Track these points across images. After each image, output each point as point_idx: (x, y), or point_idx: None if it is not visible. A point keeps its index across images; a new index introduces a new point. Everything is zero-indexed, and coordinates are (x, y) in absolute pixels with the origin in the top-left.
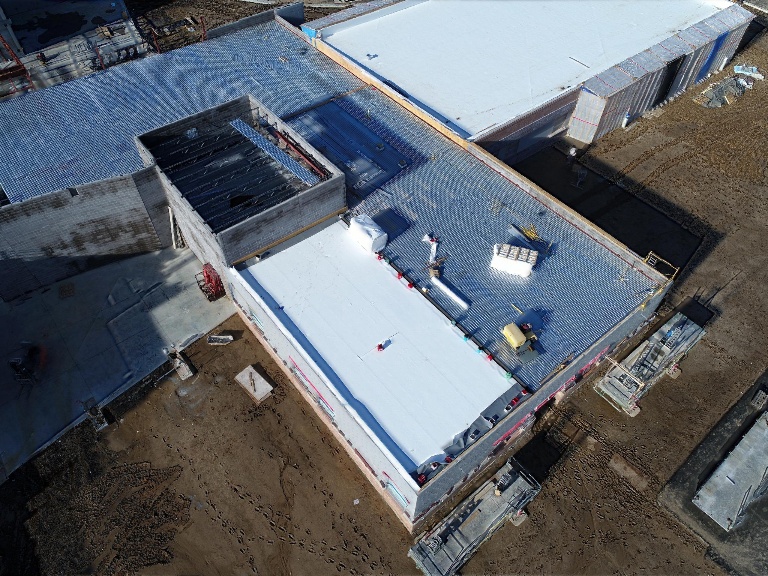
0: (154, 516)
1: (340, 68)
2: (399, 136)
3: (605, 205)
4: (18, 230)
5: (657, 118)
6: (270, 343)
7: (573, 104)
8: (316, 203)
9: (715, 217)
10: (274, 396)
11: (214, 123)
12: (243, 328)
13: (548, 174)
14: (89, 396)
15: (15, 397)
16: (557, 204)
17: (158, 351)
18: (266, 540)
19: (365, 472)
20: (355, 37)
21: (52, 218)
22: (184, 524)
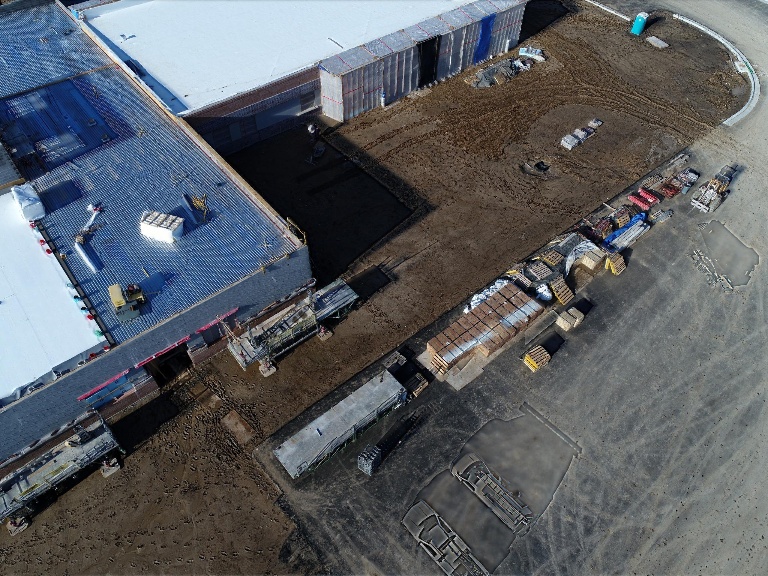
0: None
1: (97, 48)
2: (118, 112)
3: (331, 180)
4: None
5: (421, 98)
6: None
7: (316, 83)
8: None
9: (436, 191)
10: None
11: None
12: None
13: (288, 151)
14: None
15: None
16: (233, 175)
17: None
18: None
19: None
20: (121, 18)
21: None
22: None
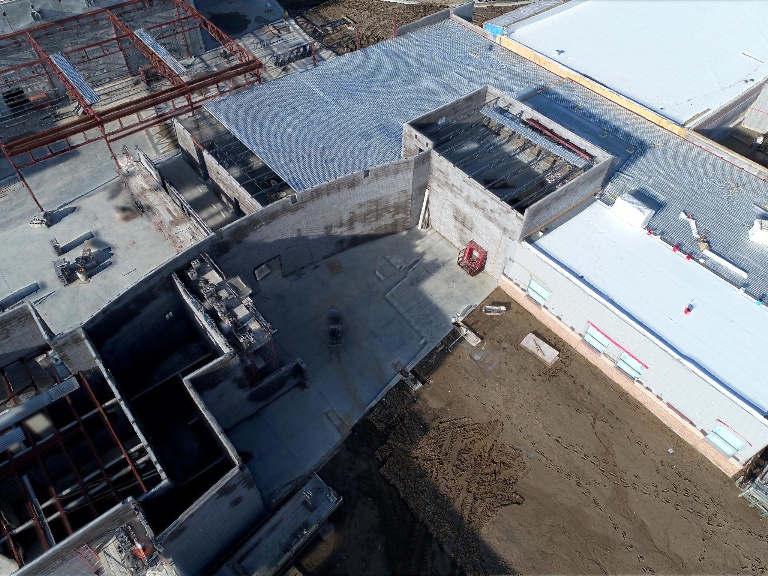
0: (493, 464)
1: (530, 63)
2: (615, 125)
3: None
4: (316, 209)
5: None
6: (552, 312)
7: (756, 96)
8: (587, 183)
9: None
10: (561, 360)
11: (465, 112)
12: (509, 300)
13: None
14: (395, 360)
15: (328, 361)
16: None
17: (441, 320)
18: (602, 484)
19: (672, 425)
20: (536, 34)
21: (343, 198)
22: (523, 471)
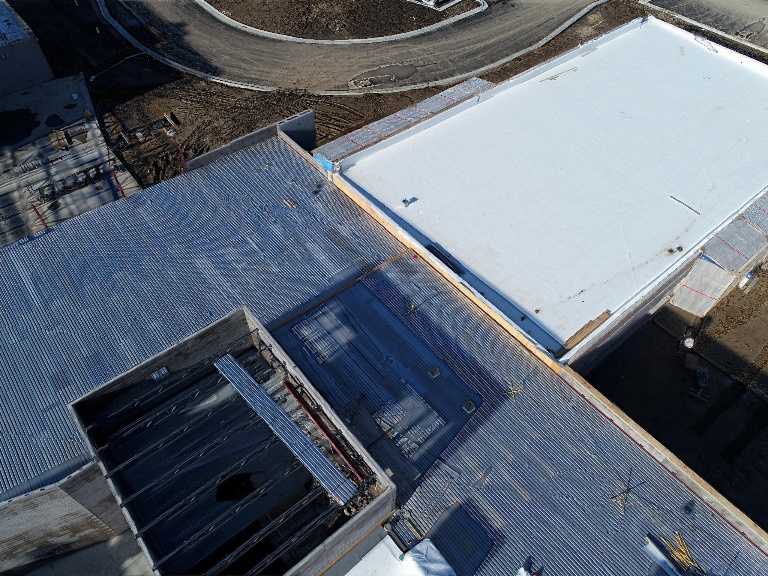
0: None
1: (366, 217)
2: (458, 347)
3: (742, 430)
4: None
5: None
6: None
7: (685, 273)
8: (351, 533)
9: None
10: None
11: None
12: None
13: (654, 372)
14: None
15: None
16: (713, 497)
17: None
18: None
19: None
20: (384, 168)
21: None
22: None
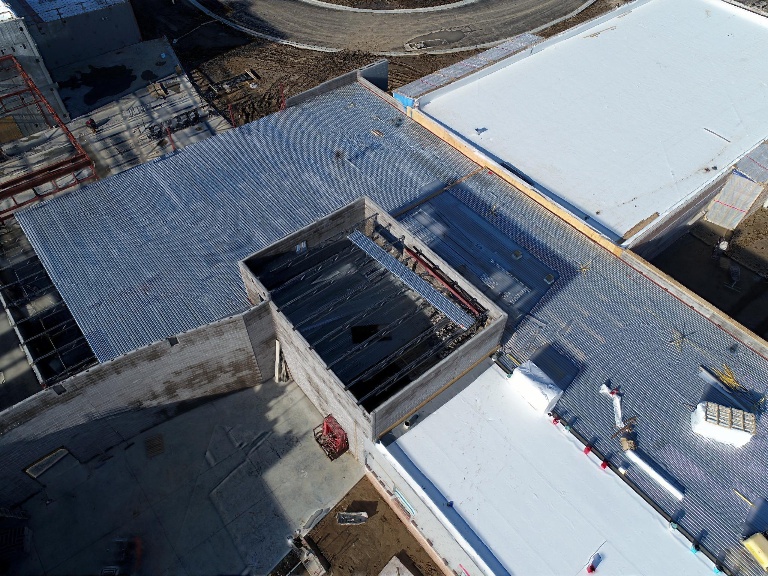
0: None
1: (444, 144)
2: (535, 238)
3: None
4: (105, 390)
5: None
6: (421, 531)
7: (720, 188)
8: (473, 351)
9: None
10: None
11: None
12: (376, 498)
13: (694, 271)
14: None
15: None
16: (753, 338)
17: (278, 536)
18: None
19: None
20: (456, 105)
21: (145, 371)
22: None
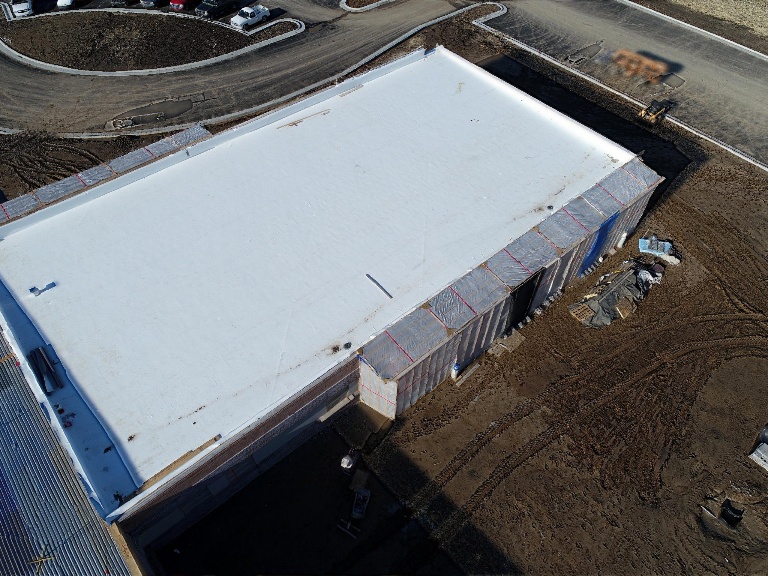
0: None
1: None
2: (4, 494)
3: None
4: None
5: (510, 354)
6: None
7: (352, 375)
8: None
9: None
10: None
11: None
12: None
13: (308, 497)
14: None
15: None
16: None
17: None
18: None
19: None
20: (36, 243)
21: None
22: None
